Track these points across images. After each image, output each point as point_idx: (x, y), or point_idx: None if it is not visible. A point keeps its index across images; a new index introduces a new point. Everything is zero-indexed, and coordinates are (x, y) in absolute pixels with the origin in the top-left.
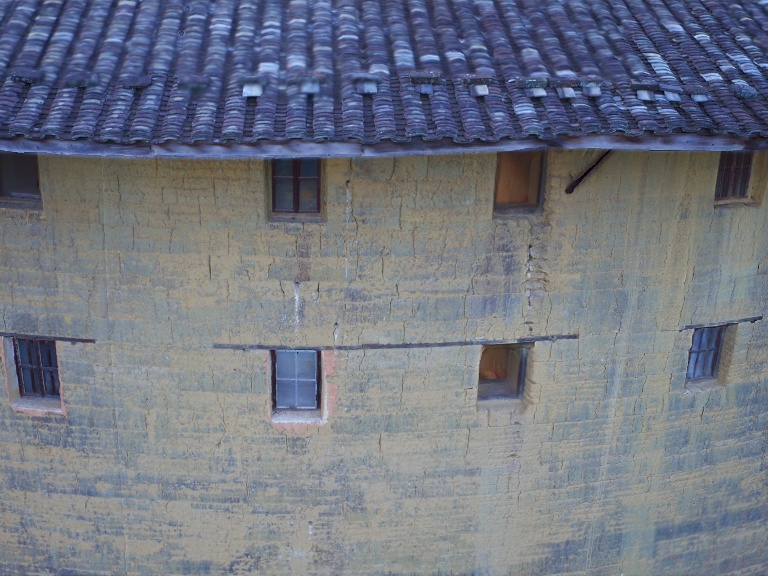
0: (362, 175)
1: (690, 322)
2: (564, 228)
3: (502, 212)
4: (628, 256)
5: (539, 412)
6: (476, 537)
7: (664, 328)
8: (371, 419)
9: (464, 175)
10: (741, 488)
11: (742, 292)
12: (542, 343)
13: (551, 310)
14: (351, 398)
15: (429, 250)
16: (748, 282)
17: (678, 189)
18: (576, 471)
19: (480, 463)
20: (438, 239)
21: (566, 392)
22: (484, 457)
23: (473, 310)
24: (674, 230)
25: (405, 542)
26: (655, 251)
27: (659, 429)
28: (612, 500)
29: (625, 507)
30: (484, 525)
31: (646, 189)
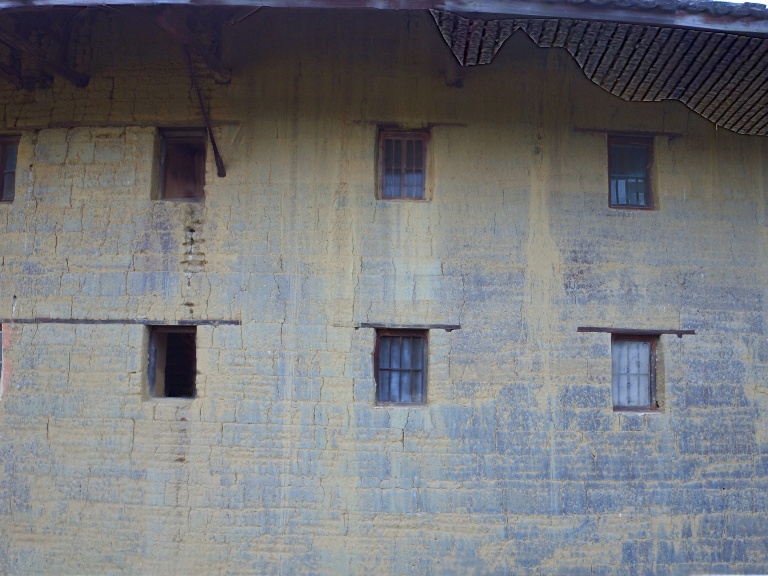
0: (42, 159)
1: (366, 319)
2: (218, 209)
3: (169, 200)
4: (286, 240)
5: (205, 408)
6: (144, 563)
7: (336, 323)
8: (40, 399)
9: (126, 159)
10: (481, 558)
11: (426, 293)
12: (204, 328)
13: (210, 292)
14: (23, 375)
15: (95, 226)
16: (432, 282)
17: (332, 177)
18: (252, 489)
19: (146, 464)
20: (103, 216)
21: (233, 387)
22: (150, 457)
23: (134, 287)
24: (333, 217)
25: (69, 558)
26: (315, 237)
27: (348, 449)
28: (300, 537)
29: (318, 551)
30: (152, 547)
31: (298, 175)
